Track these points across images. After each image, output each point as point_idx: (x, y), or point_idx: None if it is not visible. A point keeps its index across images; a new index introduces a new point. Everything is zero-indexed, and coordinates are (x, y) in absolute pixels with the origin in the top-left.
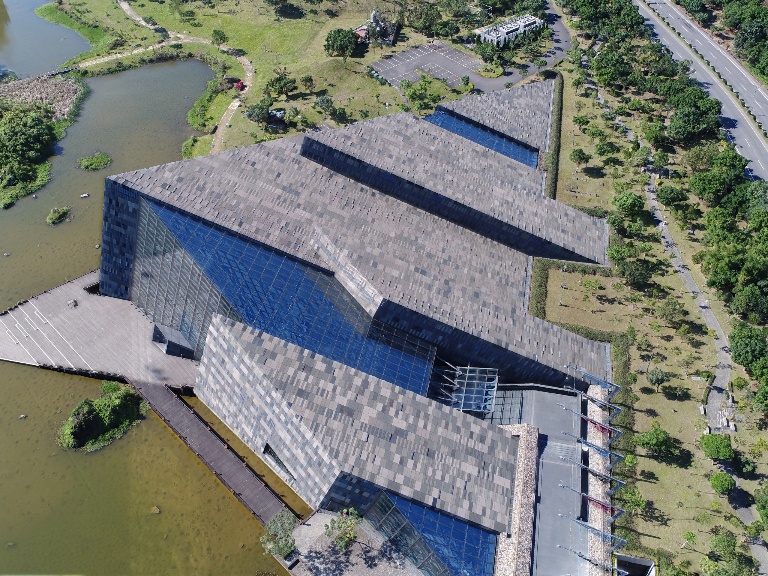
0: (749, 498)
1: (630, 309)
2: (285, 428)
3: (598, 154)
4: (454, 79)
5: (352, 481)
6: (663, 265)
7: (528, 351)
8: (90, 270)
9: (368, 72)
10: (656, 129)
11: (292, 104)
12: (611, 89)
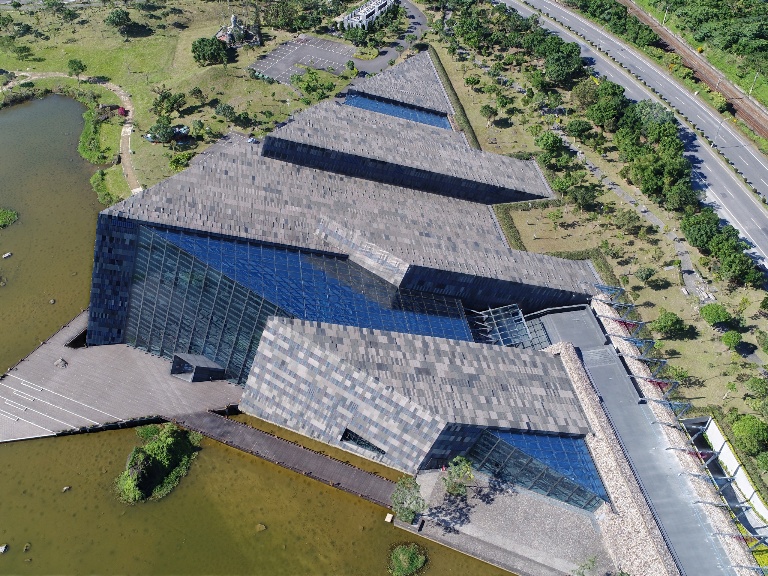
0: (750, 346)
1: (590, 228)
2: (372, 405)
3: (501, 107)
4: (336, 67)
5: (456, 430)
6: (597, 186)
7: (538, 281)
8: (61, 326)
9: (252, 74)
10: (538, 76)
11: (188, 119)
12: (483, 50)
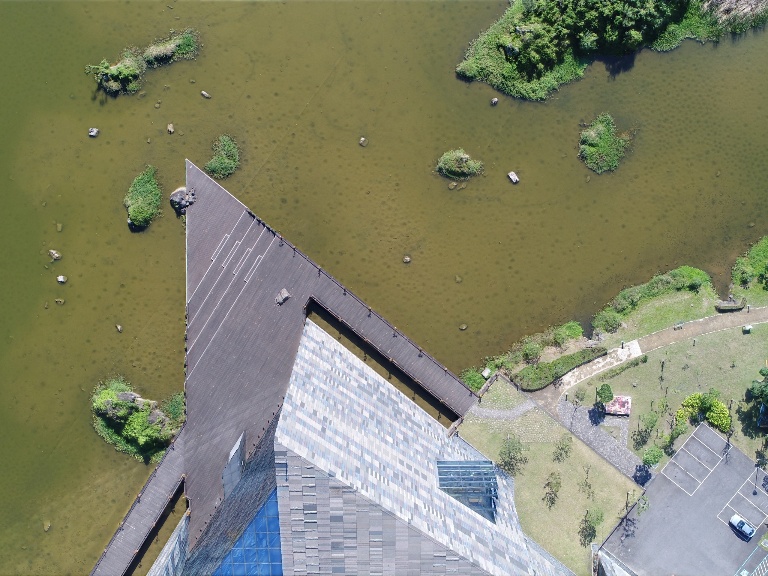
0: None
1: None
2: None
3: None
4: None
5: None
6: None
7: None
8: None
9: None
10: None
11: None
12: None
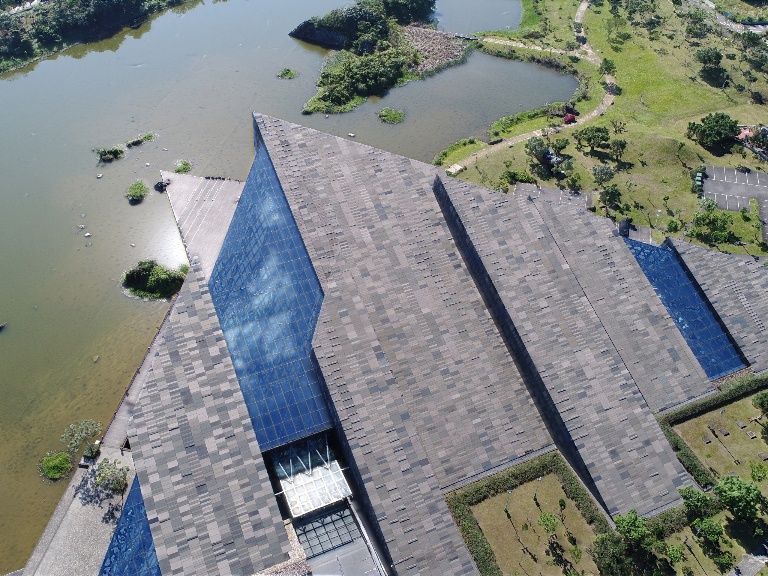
0: None
1: None
2: None
3: None
4: None
5: None
6: None
7: (383, 504)
8: None
9: (693, 171)
10: None
11: (586, 159)
12: None
